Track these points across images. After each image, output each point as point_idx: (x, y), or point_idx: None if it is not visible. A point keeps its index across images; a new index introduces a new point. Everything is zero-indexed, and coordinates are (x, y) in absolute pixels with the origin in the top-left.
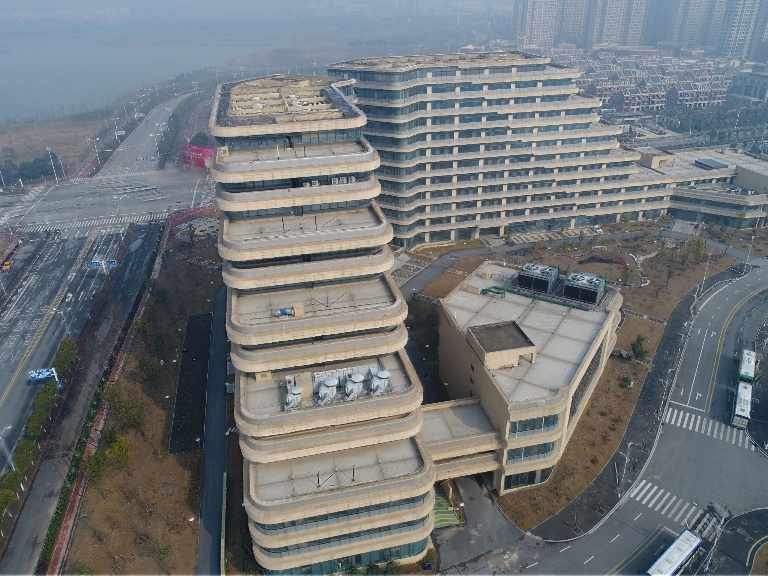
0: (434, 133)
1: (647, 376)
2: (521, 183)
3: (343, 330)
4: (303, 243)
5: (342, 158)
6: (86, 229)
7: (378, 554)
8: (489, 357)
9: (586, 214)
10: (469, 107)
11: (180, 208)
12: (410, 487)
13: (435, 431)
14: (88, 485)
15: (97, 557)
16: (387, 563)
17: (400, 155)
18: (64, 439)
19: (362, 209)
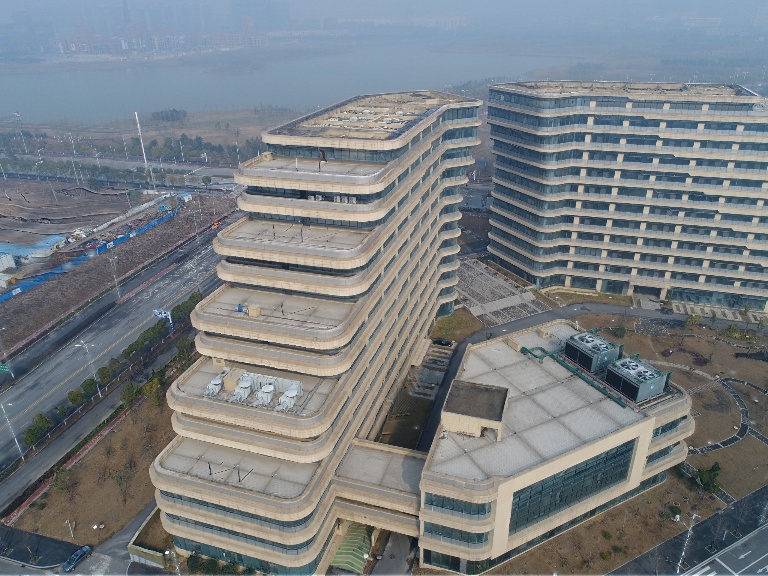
0: (590, 168)
1: (710, 517)
2: (697, 243)
3: (275, 340)
4: (275, 251)
5: (339, 178)
6: None
7: (258, 562)
8: (446, 416)
9: None
10: (638, 145)
11: None
12: (276, 509)
13: (369, 471)
14: (134, 409)
15: (97, 465)
16: (263, 574)
17: (545, 187)
18: (150, 369)
19: (365, 231)
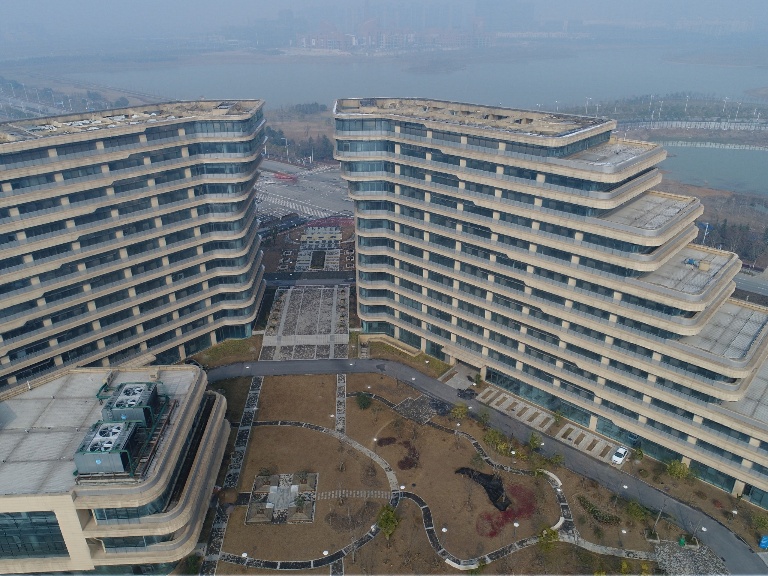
0: (402, 205)
1: None
2: (510, 318)
3: None
4: None
5: None
6: (272, 206)
7: None
8: None
9: (614, 420)
10: (442, 184)
11: (346, 214)
12: None
13: None
14: None
15: None
16: None
17: None
18: None
19: None
